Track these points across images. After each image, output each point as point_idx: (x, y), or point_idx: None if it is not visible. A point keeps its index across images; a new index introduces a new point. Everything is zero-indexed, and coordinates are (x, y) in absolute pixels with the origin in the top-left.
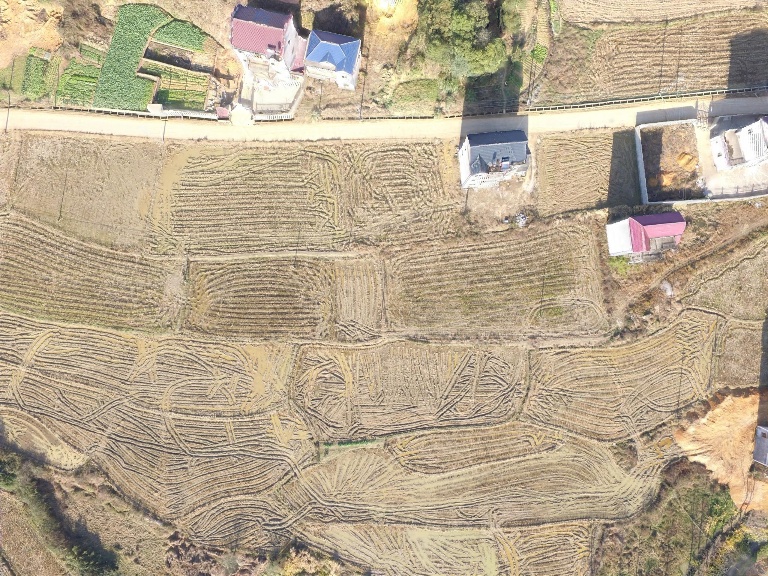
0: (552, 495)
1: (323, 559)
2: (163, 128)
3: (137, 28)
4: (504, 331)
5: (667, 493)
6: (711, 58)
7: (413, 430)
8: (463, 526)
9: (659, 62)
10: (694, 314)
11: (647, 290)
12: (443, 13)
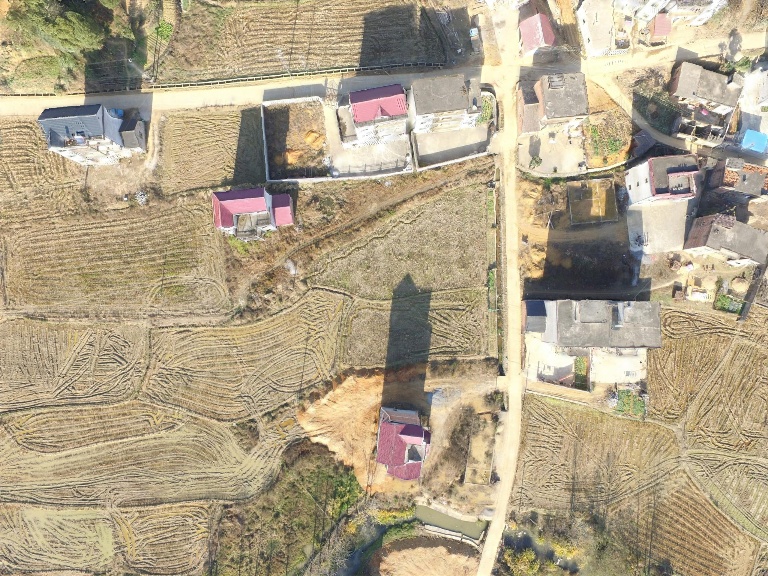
0: (171, 475)
1: None
2: None
3: None
4: (124, 309)
5: (284, 474)
6: (343, 36)
7: (30, 408)
8: (79, 506)
9: (290, 39)
10: (320, 293)
11: (271, 269)
12: None
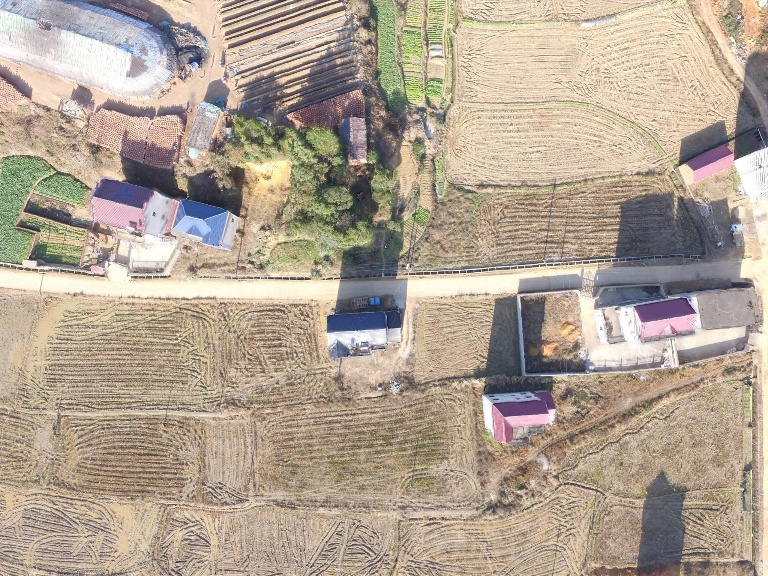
0: None
1: None
2: (40, 281)
3: (19, 180)
4: (374, 500)
5: None
6: (599, 224)
7: None
8: None
9: (545, 227)
10: (572, 489)
11: (523, 463)
12: (305, 195)
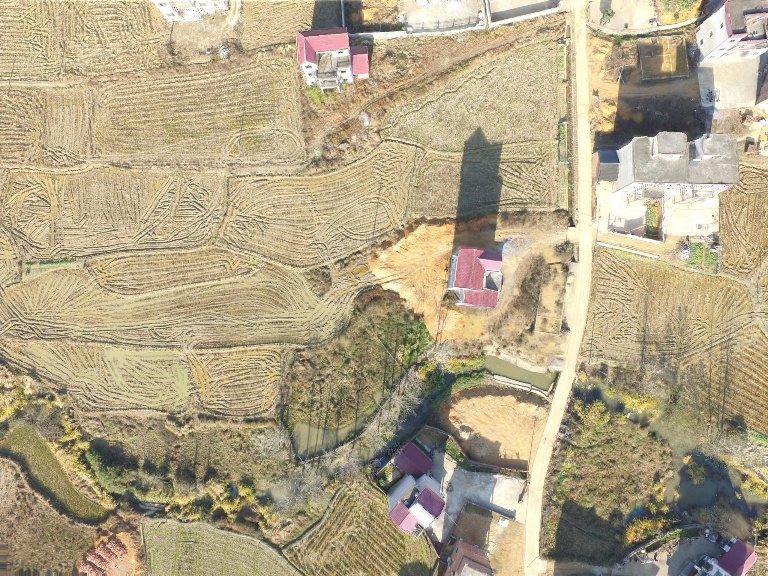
0: (246, 319)
1: (21, 374)
2: None
3: None
4: (204, 159)
5: (356, 318)
6: None
7: (112, 252)
8: (157, 347)
9: None
10: (393, 146)
11: (345, 121)
12: None
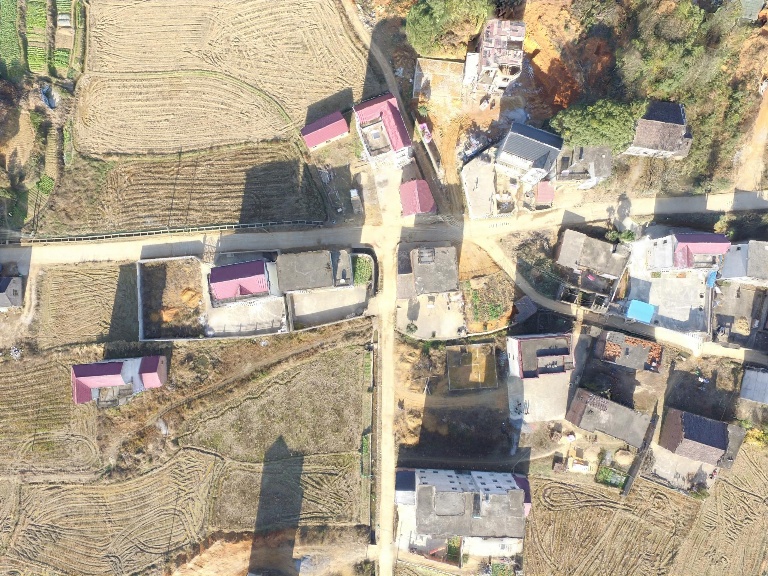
0: None
1: None
2: None
3: None
4: None
5: None
6: (224, 191)
7: None
8: None
9: (170, 195)
10: (192, 453)
11: (142, 428)
12: None
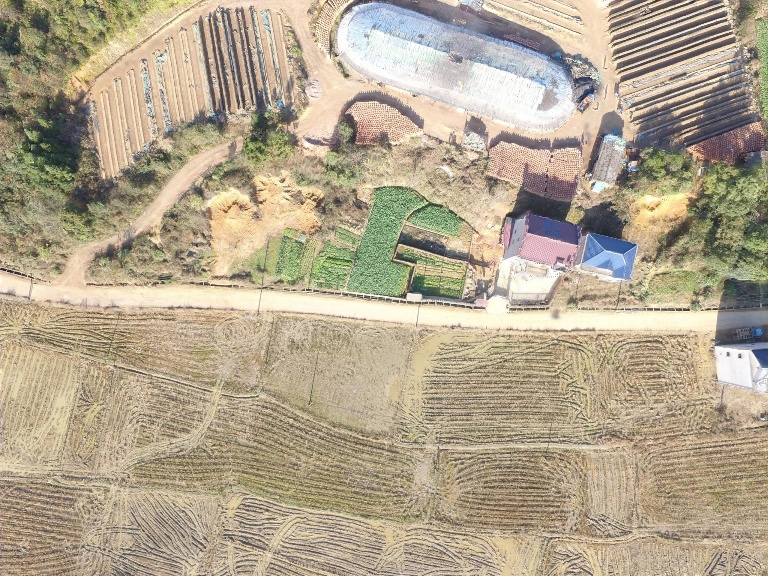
0: None
1: None
2: (416, 314)
3: (393, 212)
4: (756, 530)
5: None
6: None
7: None
8: None
9: None
10: None
11: None
12: (736, 230)
